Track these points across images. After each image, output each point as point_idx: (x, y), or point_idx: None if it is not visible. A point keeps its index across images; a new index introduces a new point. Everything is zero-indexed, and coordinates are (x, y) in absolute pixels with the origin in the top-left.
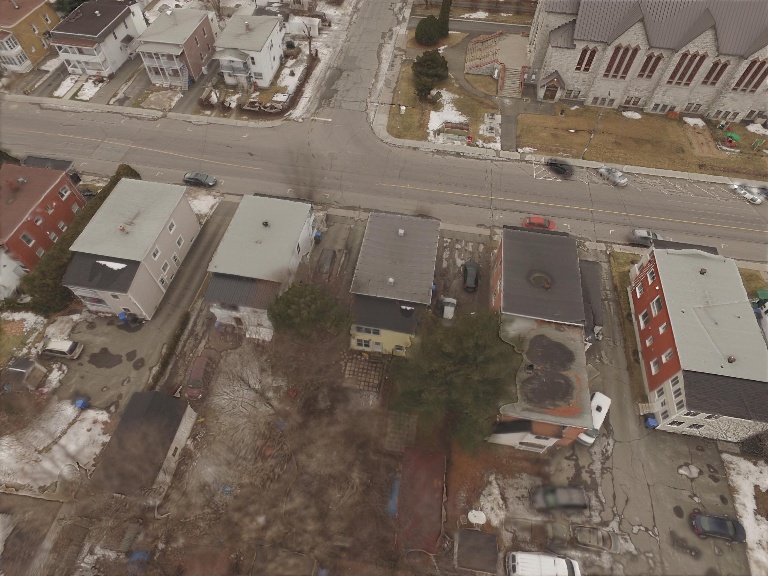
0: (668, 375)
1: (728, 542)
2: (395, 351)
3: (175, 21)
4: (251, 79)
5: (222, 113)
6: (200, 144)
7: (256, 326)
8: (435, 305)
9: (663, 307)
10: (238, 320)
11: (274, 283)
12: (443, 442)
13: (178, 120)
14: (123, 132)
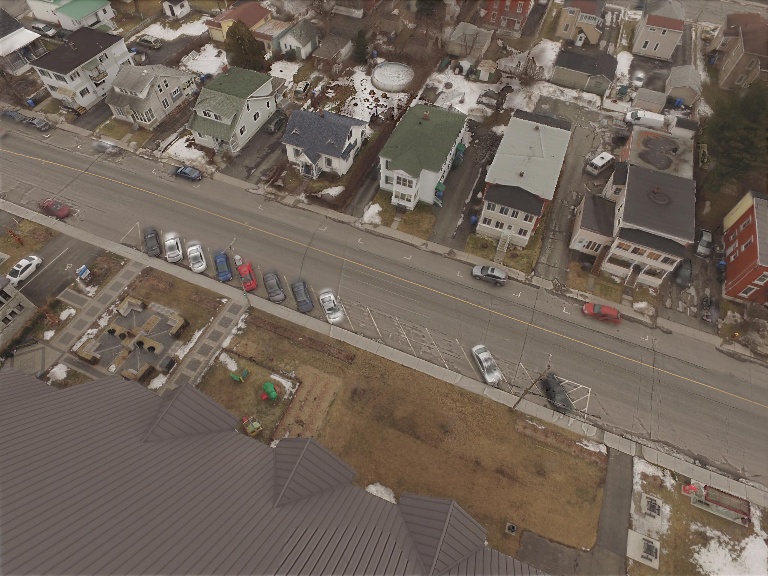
0: None
1: None
2: None
3: None
4: None
5: None
6: None
7: None
8: (714, 255)
9: None
10: None
11: None
12: (698, 175)
13: None
14: None
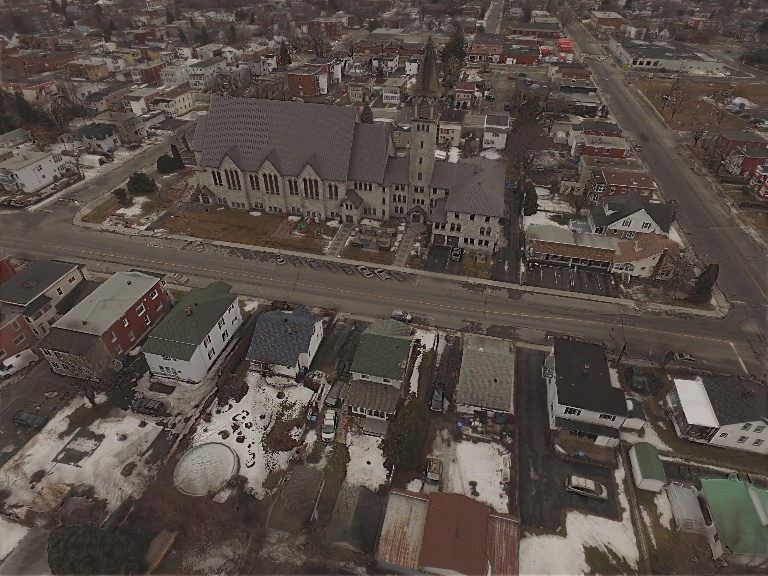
0: None
1: (30, 428)
2: None
3: None
4: (19, 187)
5: None
6: None
7: None
8: None
9: None
10: None
11: None
12: None
13: None
14: None
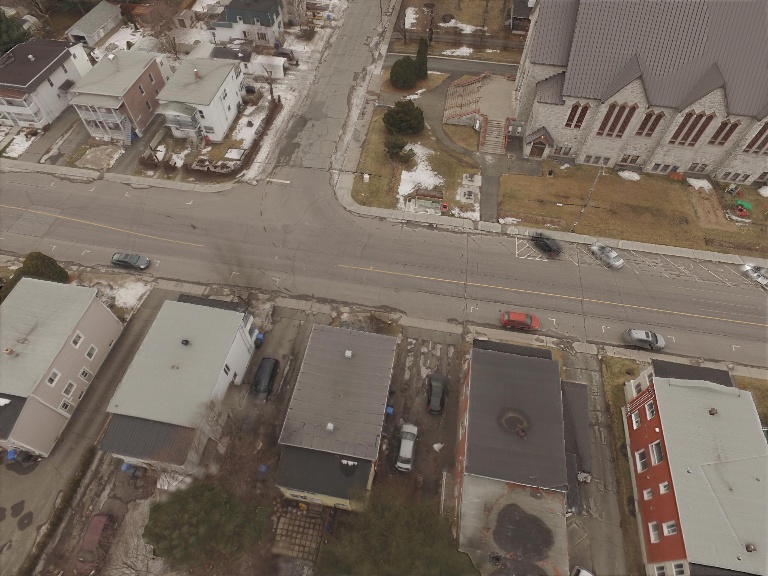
0: (670, 555)
1: None
2: (338, 505)
3: (117, 67)
4: (202, 133)
5: (166, 174)
6: (137, 213)
7: (170, 472)
8: (392, 433)
9: (664, 460)
10: (148, 464)
11: (187, 429)
12: None
13: (116, 182)
14: (51, 198)
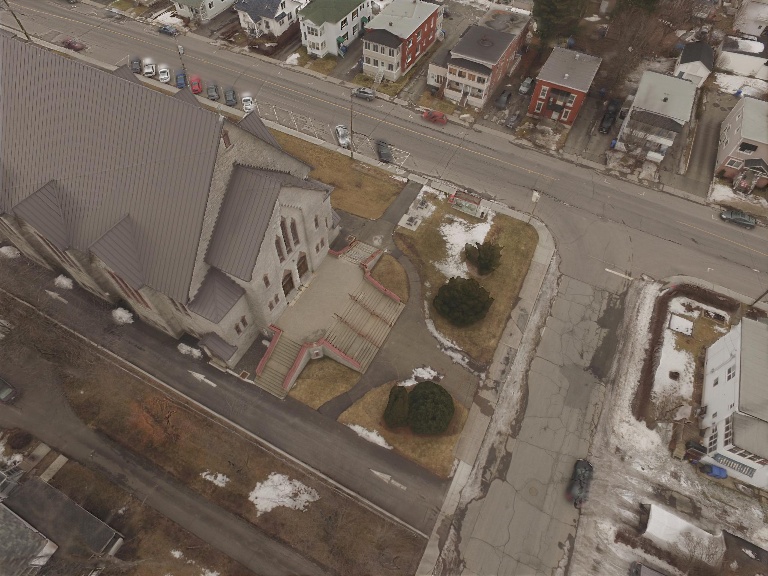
0: None
1: None
2: None
3: None
4: None
5: (756, 314)
6: (761, 270)
7: None
8: (532, 94)
9: None
10: None
11: None
12: None
13: None
14: None
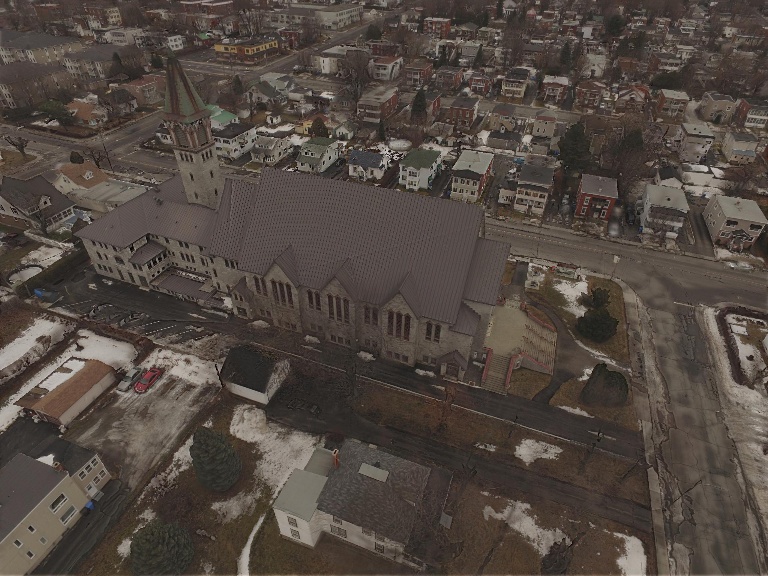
0: None
1: None
2: None
3: None
4: None
5: None
6: None
7: None
8: (571, 204)
9: None
10: None
11: None
12: None
13: None
14: None
